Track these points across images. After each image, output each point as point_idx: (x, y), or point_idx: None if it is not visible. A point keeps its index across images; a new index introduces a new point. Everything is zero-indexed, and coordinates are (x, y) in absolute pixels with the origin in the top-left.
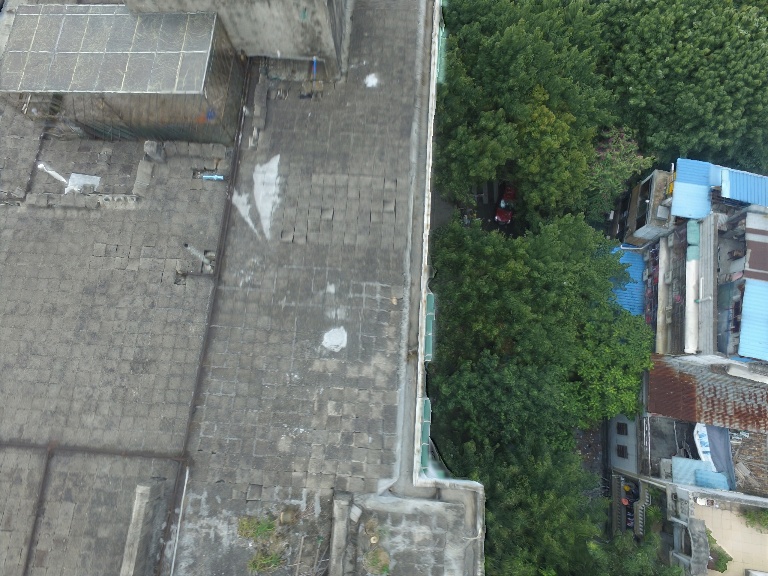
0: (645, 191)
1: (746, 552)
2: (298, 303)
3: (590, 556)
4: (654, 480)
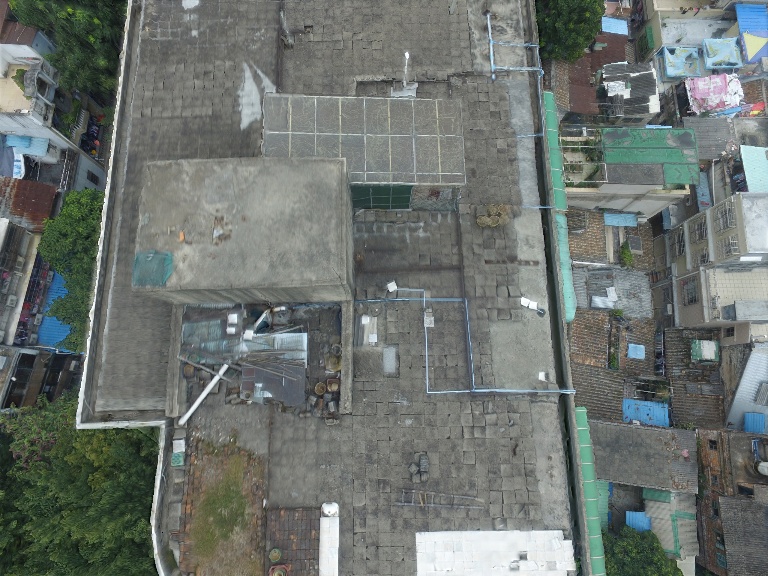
0: (16, 398)
1: (3, 88)
2: (218, 21)
3: (114, 73)
4: (64, 140)
